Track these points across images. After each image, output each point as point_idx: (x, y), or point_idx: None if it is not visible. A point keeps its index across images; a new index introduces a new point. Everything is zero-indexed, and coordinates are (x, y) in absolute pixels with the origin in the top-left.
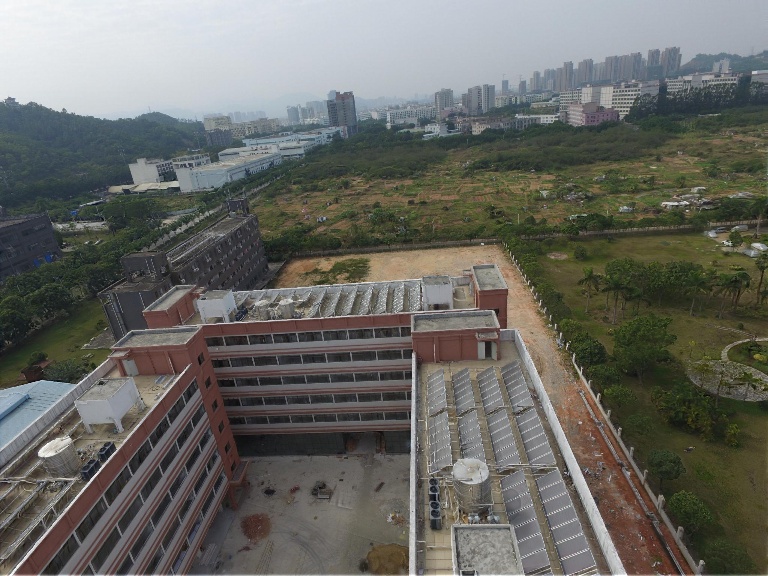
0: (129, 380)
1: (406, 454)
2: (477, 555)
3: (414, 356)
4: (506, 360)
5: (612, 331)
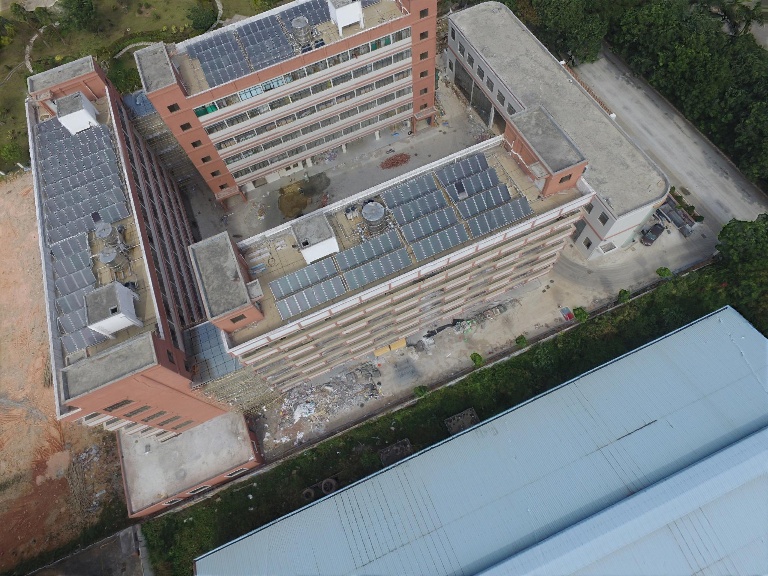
0: (295, 223)
1: (200, 234)
2: (344, 1)
3: (191, 96)
4: (178, 62)
5: (11, 136)
